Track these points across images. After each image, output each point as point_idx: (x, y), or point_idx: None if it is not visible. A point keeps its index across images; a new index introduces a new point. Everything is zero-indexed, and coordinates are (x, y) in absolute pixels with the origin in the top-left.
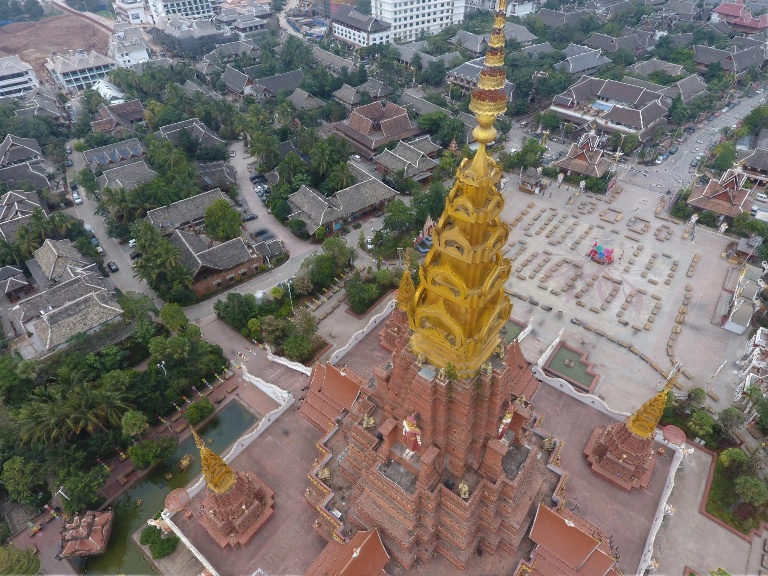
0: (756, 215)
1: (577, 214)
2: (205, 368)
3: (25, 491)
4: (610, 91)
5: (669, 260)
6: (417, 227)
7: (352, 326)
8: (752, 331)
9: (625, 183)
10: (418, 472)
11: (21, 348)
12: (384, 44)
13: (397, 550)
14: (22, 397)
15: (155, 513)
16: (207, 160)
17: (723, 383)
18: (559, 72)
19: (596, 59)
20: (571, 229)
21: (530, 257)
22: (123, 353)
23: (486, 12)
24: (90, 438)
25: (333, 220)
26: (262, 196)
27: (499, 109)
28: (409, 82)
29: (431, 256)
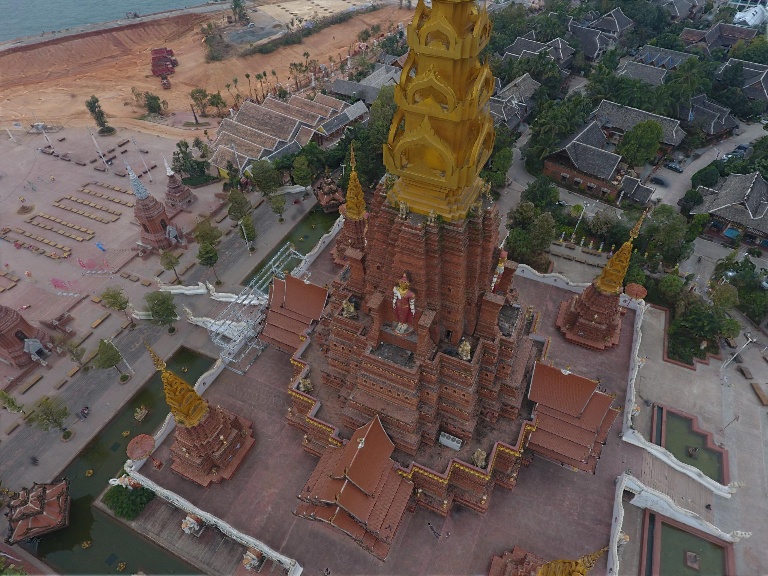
0: None
1: None
2: None
3: None
4: None
5: None
6: None
7: None
8: None
9: None
10: None
11: None
12: None
13: None
14: None
15: None
16: (721, 103)
17: None
18: None
19: None
20: None
21: None
22: None
23: None
24: None
25: (730, 220)
26: None
27: None
28: None
29: None
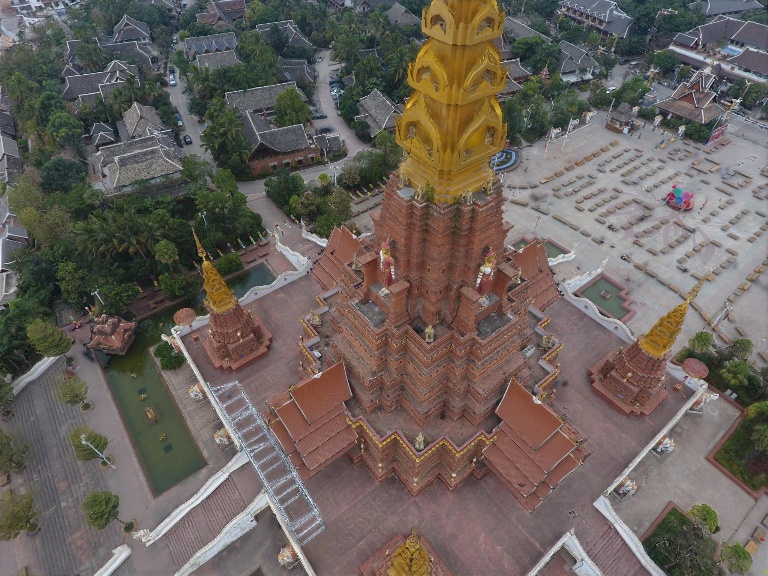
0: None
1: (665, 158)
2: (241, 228)
3: (73, 293)
4: (748, 35)
5: (762, 219)
6: None
7: None
8: None
9: (736, 136)
10: None
11: (95, 185)
12: None
13: (360, 389)
14: None
15: None
16: None
17: None
18: (692, 12)
19: (743, 2)
20: (653, 172)
21: (596, 191)
22: (176, 206)
23: None
24: (131, 262)
25: None
26: (336, 99)
27: None
28: (517, 12)
29: (423, 53)
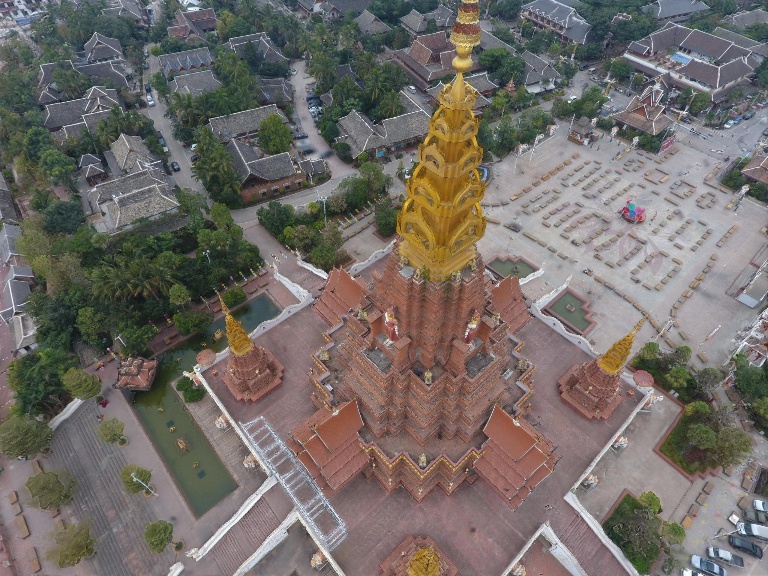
0: None
1: (621, 170)
2: (242, 262)
3: (93, 335)
4: (694, 42)
5: (703, 228)
6: None
7: (376, 247)
8: (765, 306)
9: (683, 145)
10: (394, 358)
11: (96, 224)
12: None
13: (371, 420)
14: (95, 263)
15: (190, 369)
16: (269, 76)
17: (717, 348)
18: (645, 16)
19: (691, 4)
20: (610, 184)
21: (560, 206)
22: (177, 241)
23: None
24: (145, 303)
25: (376, 147)
26: (315, 117)
27: (471, 42)
28: (482, 13)
29: (418, 170)
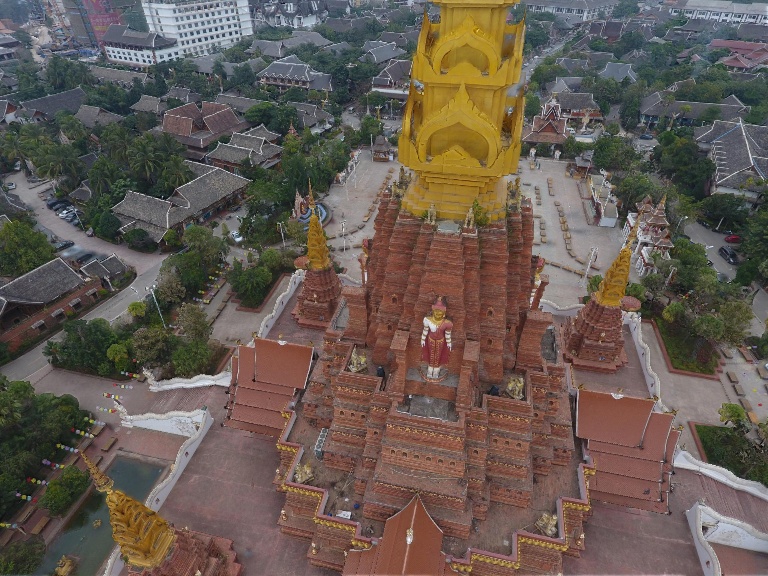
0: (576, 140)
1: None
2: (57, 426)
3: None
4: None
5: (530, 187)
6: (285, 209)
7: (251, 322)
8: (621, 222)
9: None
10: (453, 392)
11: None
12: (175, 61)
13: (449, 516)
14: None
15: None
16: None
17: None
18: (366, 63)
19: (393, 51)
20: None
21: None
22: None
23: (273, 27)
24: None
25: (182, 220)
26: (72, 221)
27: None
28: (217, 92)
29: (425, 40)
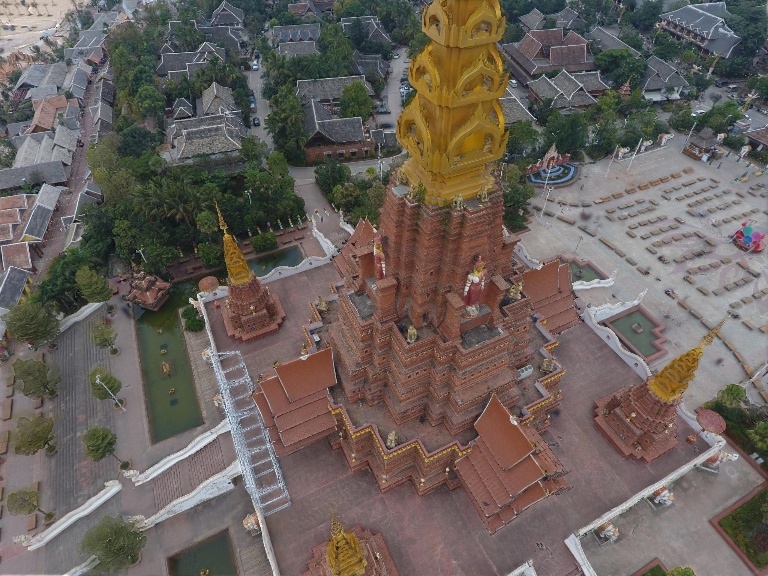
0: None
1: (744, 193)
2: (282, 210)
3: (125, 249)
4: None
5: None
6: None
7: None
8: None
9: None
10: None
11: (164, 154)
12: None
13: (345, 378)
14: None
15: None
16: None
17: None
18: None
19: None
20: (726, 206)
21: (654, 218)
22: (230, 182)
23: None
24: (177, 227)
25: None
26: None
27: None
28: (613, 22)
29: None
